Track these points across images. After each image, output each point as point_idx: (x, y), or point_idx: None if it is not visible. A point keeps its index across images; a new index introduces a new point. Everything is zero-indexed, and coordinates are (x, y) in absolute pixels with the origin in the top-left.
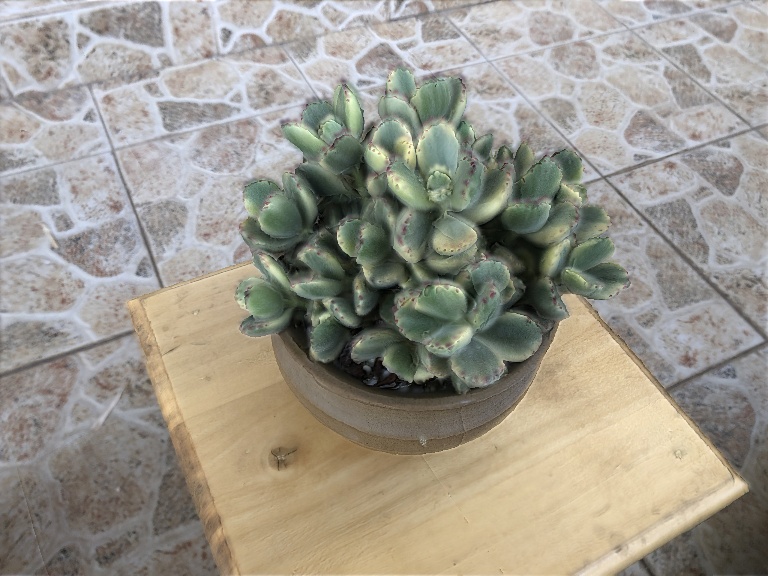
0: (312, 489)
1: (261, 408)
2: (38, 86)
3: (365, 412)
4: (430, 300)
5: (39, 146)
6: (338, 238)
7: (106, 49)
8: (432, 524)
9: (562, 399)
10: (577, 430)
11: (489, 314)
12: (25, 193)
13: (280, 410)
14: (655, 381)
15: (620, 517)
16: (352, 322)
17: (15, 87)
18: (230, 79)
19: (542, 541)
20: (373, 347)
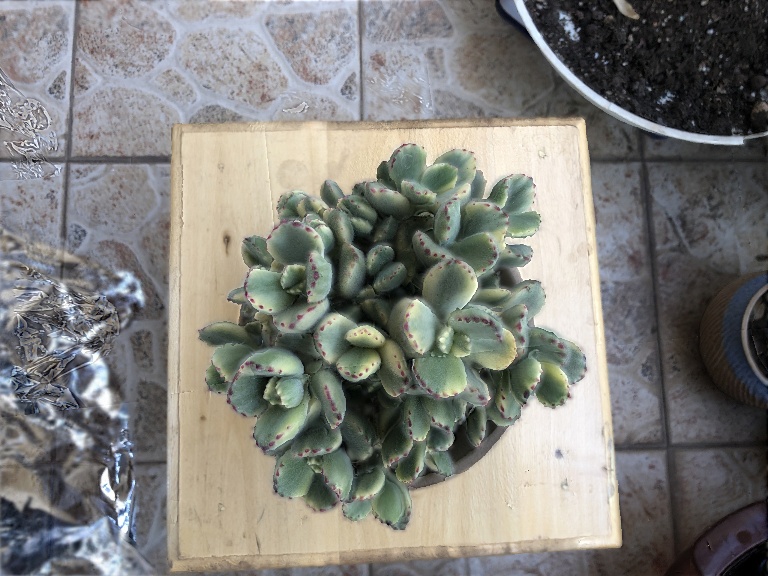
0: None
1: None
2: None
3: None
4: None
5: None
6: (418, 440)
7: None
8: None
9: None
10: None
11: None
12: None
13: None
14: (474, 123)
15: (568, 235)
16: (452, 435)
17: None
18: None
19: (560, 305)
20: None
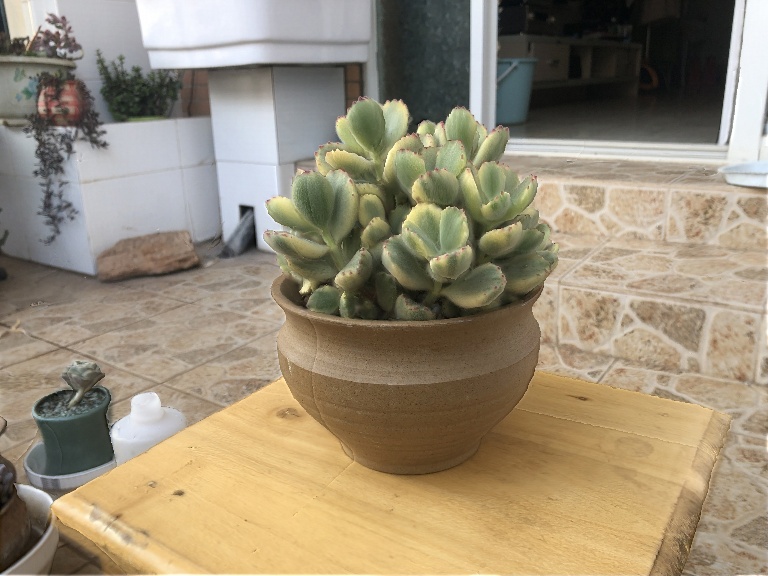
0: (271, 433)
1: None
2: (579, 343)
3: None
4: None
5: None
6: None
7: (644, 335)
8: (278, 496)
9: (502, 538)
10: (472, 561)
11: (302, 189)
12: None
13: None
14: None
15: None
16: None
17: (563, 337)
18: (745, 401)
19: (305, 570)
20: None
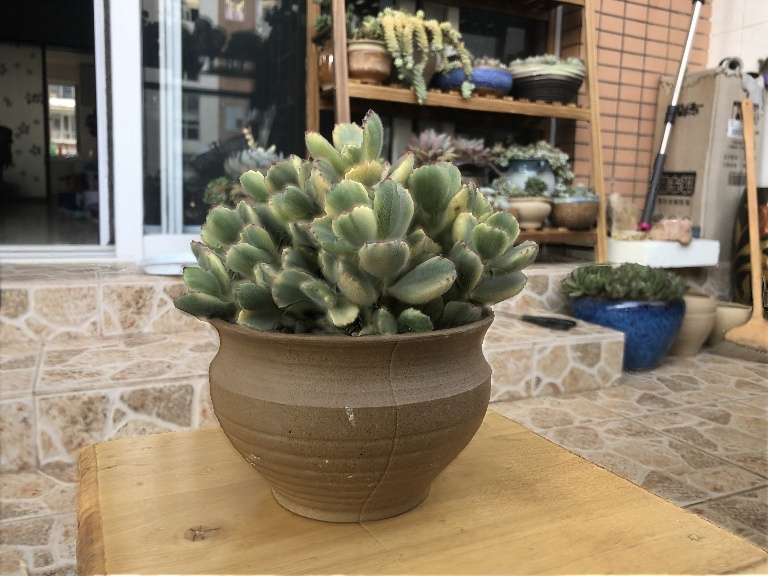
0: (229, 554)
1: (190, 501)
2: (66, 457)
3: (288, 381)
4: (336, 194)
5: (47, 500)
6: (269, 201)
7: (137, 425)
8: None
9: (542, 499)
10: (562, 519)
11: (387, 197)
12: (16, 536)
13: (211, 503)
14: None
15: None
16: None
17: (44, 456)
18: None
19: None
20: (293, 280)
